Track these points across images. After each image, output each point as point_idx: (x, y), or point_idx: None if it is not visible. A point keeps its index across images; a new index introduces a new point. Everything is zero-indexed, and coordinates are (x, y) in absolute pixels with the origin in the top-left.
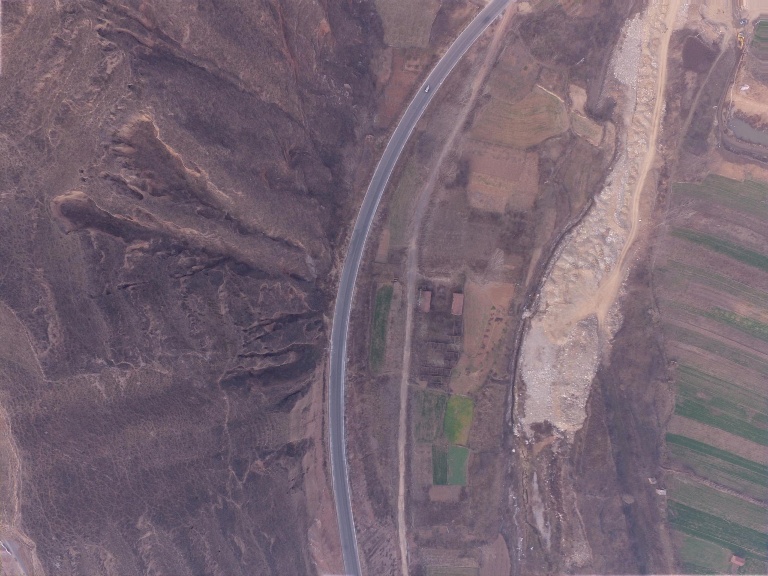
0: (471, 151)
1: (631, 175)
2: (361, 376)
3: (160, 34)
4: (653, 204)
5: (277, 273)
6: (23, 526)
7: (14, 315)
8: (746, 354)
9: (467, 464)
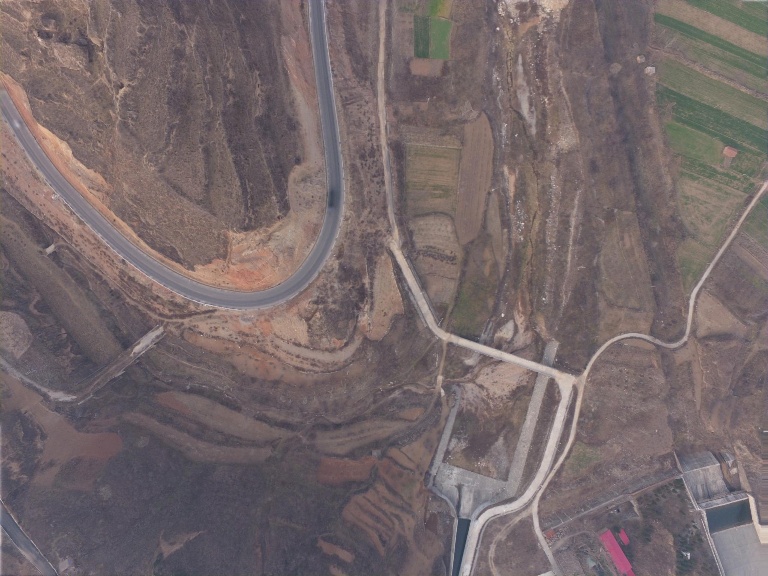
0: None
1: None
2: None
3: None
4: None
5: None
6: None
7: None
8: None
9: (450, 38)
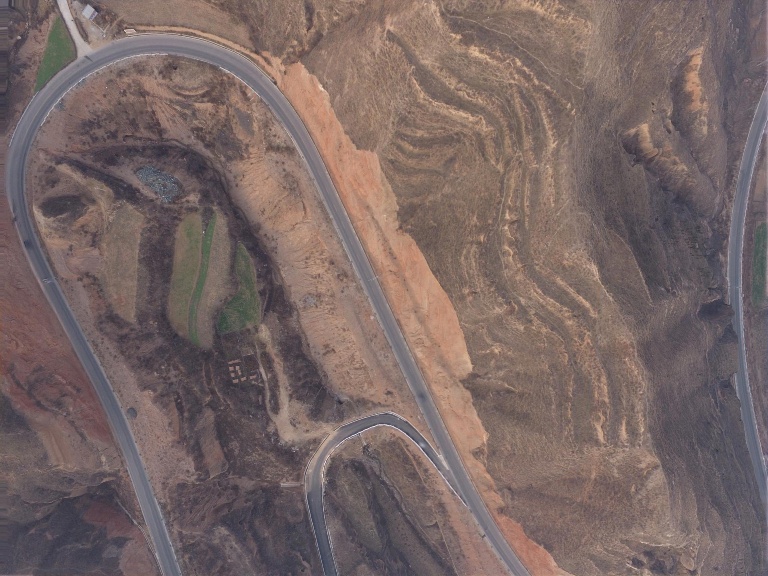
0: None
1: None
2: (748, 311)
3: None
4: None
5: (701, 212)
6: (653, 445)
7: (624, 243)
8: None
9: None
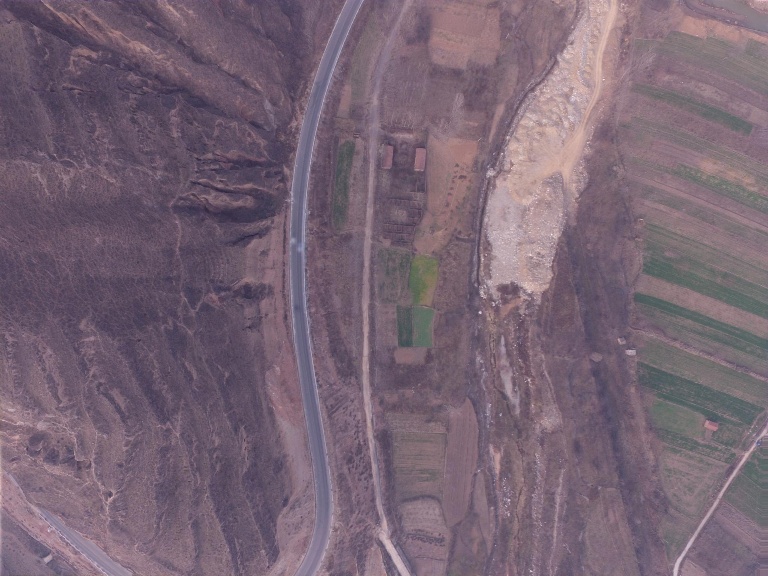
0: (432, 7)
1: (593, 34)
2: (323, 232)
3: None
4: (616, 62)
5: (234, 114)
6: None
7: None
8: (713, 212)
9: (433, 325)
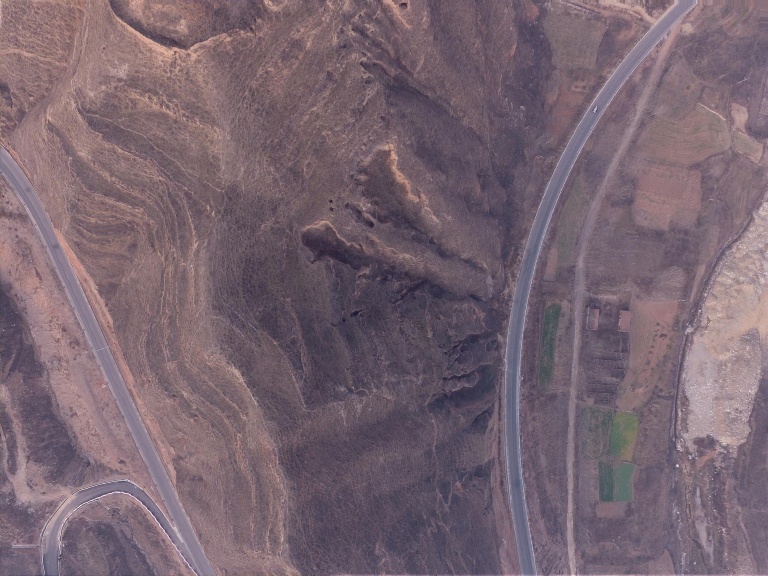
0: None
1: None
2: (532, 394)
3: (400, 64)
4: None
5: (463, 294)
6: (290, 557)
7: (276, 346)
8: None
9: (633, 480)
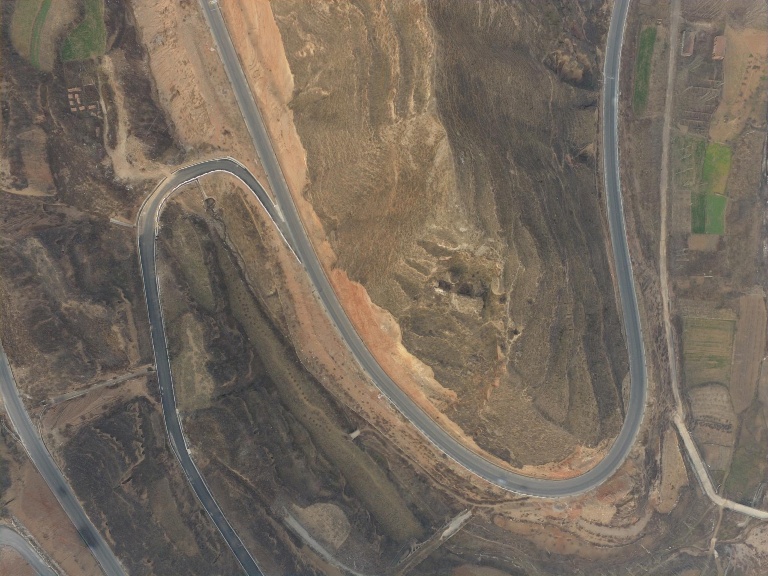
0: None
1: None
2: (627, 115)
3: None
4: None
5: None
6: (438, 110)
7: None
8: None
9: (725, 213)
